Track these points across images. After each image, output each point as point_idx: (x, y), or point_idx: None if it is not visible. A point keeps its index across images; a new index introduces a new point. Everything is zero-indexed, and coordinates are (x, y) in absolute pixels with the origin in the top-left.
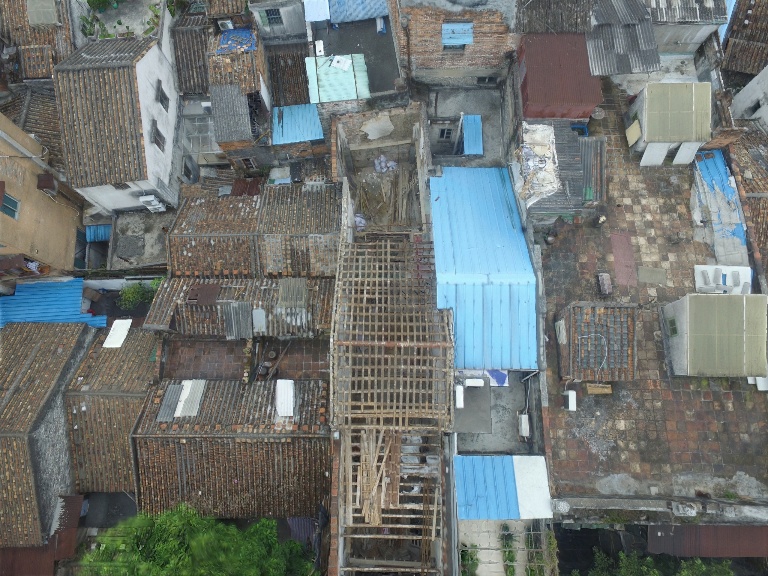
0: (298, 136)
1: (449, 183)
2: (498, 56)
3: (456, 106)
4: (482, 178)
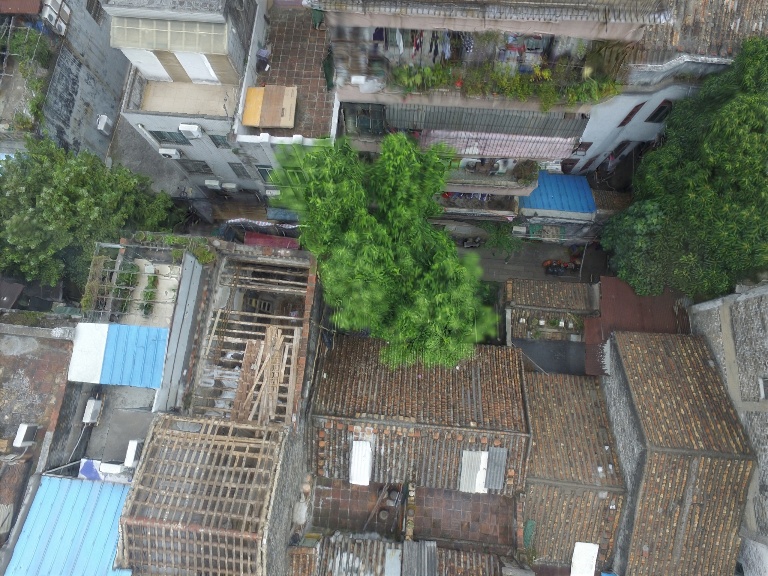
0: None
1: None
2: None
3: None
4: None
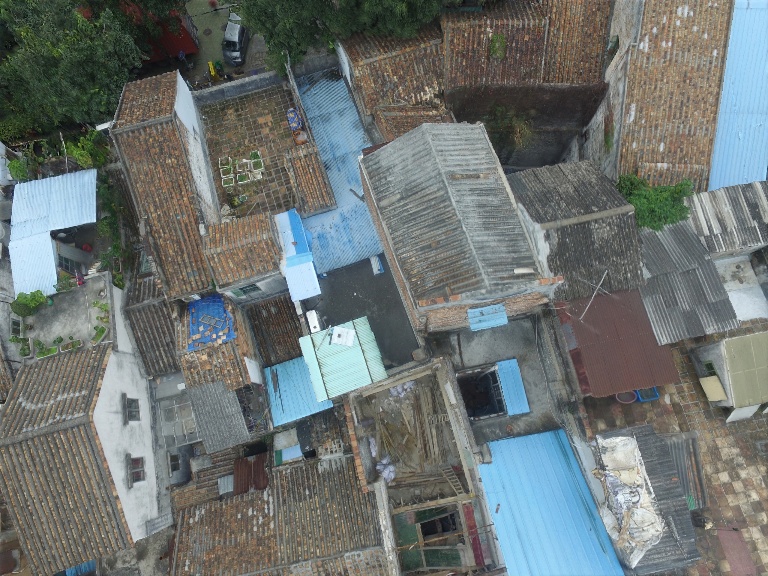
0: (302, 408)
1: (504, 473)
2: (531, 306)
3: (484, 349)
4: (540, 456)
